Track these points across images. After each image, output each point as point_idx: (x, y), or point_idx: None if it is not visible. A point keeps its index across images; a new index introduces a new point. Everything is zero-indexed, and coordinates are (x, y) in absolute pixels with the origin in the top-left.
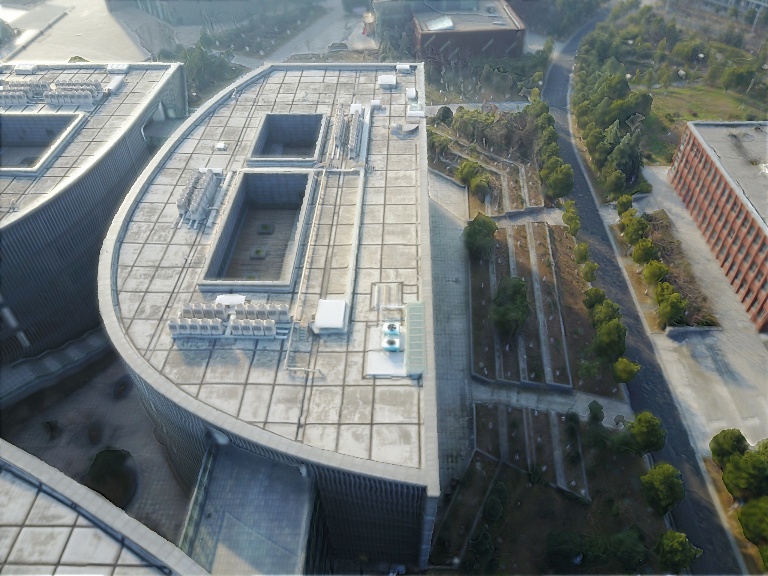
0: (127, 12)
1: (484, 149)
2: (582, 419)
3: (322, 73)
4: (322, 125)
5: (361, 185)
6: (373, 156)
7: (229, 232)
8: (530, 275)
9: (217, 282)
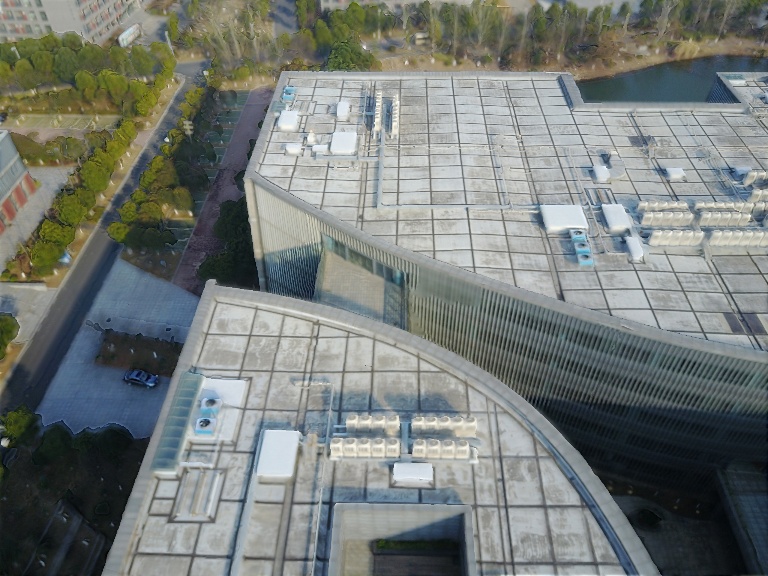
0: None
1: None
2: None
3: None
4: None
5: None
6: None
7: None
8: None
9: (441, 506)
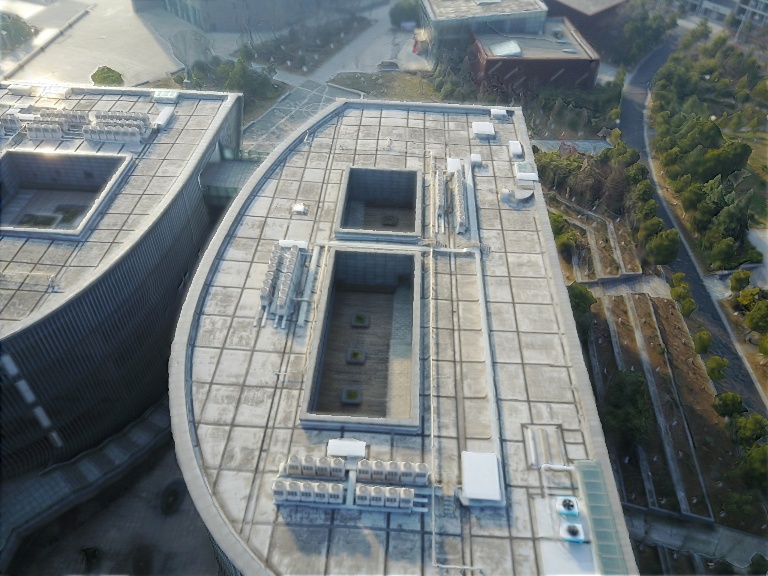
0: (154, 14)
1: (564, 198)
2: (738, 572)
3: (404, 114)
4: (419, 186)
5: (480, 273)
6: (485, 231)
7: (323, 331)
8: (639, 363)
9: (325, 418)
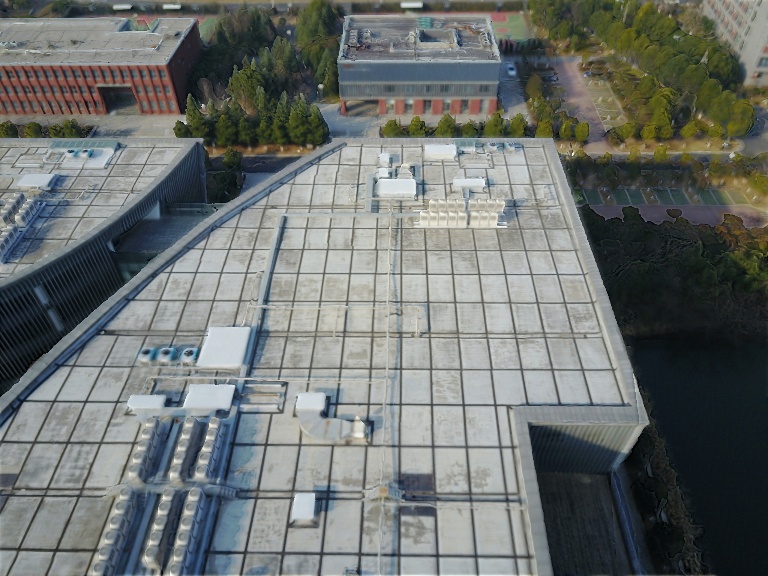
0: None
1: None
2: None
3: None
4: None
5: None
6: None
7: None
8: None
9: None
